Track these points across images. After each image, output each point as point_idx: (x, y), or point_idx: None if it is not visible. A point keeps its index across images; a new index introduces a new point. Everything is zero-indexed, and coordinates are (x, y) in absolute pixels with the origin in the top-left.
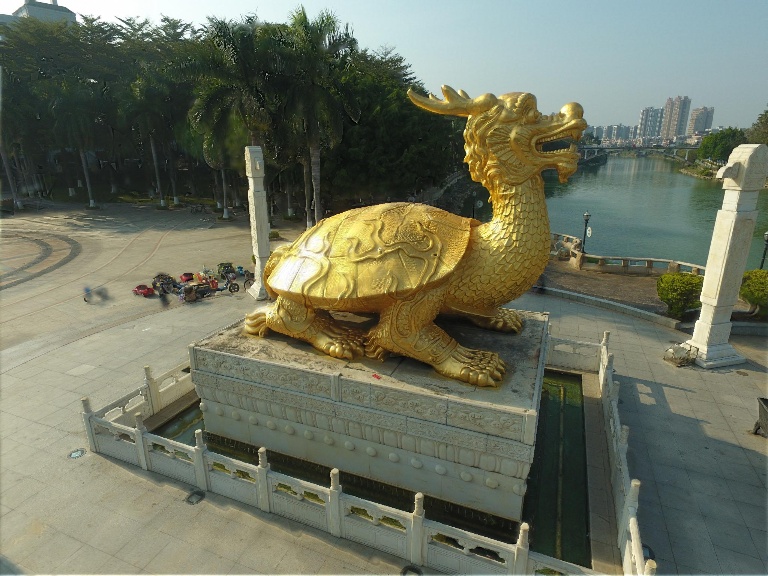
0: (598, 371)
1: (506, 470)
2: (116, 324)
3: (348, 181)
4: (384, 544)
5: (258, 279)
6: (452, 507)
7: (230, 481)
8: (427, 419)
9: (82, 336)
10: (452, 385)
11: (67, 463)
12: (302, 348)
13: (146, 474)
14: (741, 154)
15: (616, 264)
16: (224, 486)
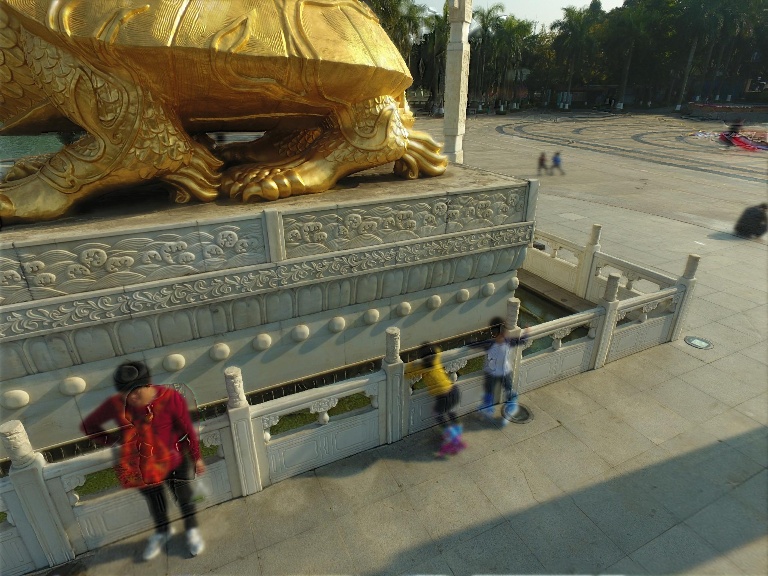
0: None
1: None
2: (734, 233)
3: None
4: None
5: None
6: None
7: None
8: None
9: (686, 220)
10: None
11: None
12: None
13: None
14: None
15: None
16: None
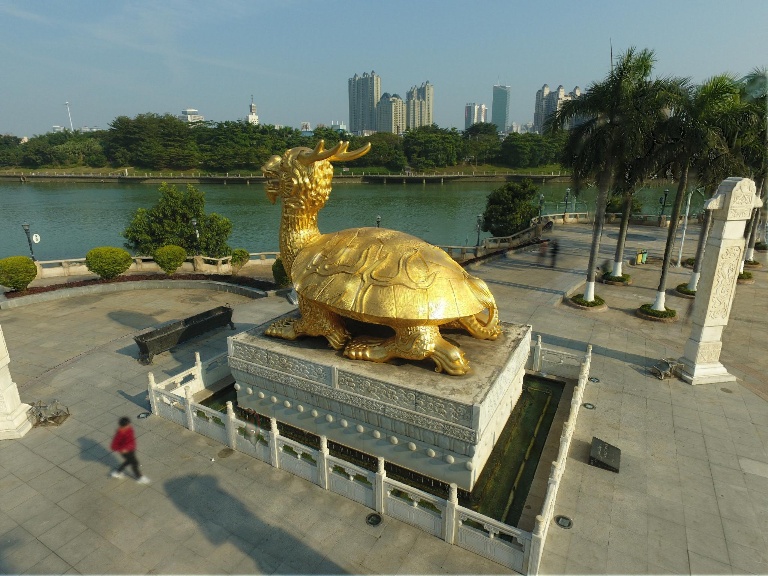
0: None
1: None
2: None
3: None
4: None
5: None
6: None
7: None
8: None
9: None
10: None
11: (591, 375)
12: None
13: None
14: None
15: None
16: None
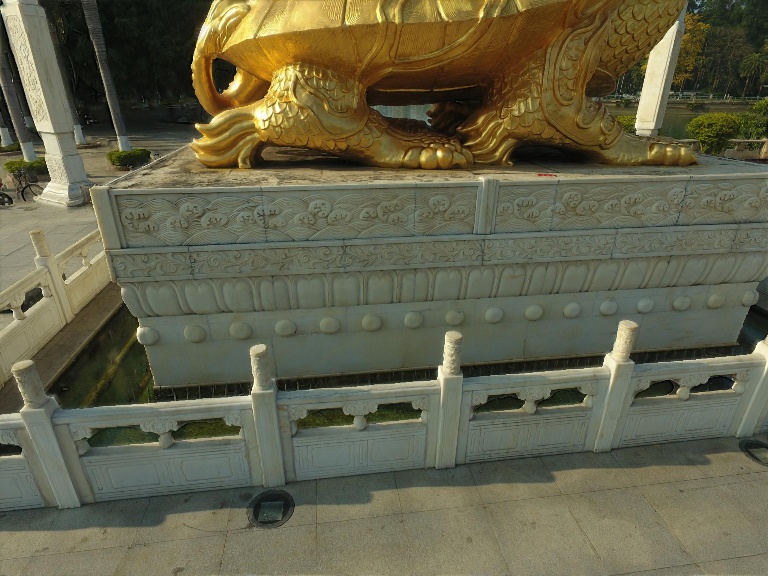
0: None
1: (744, 273)
2: None
3: (121, 69)
4: (691, 427)
5: (58, 174)
6: (665, 354)
7: (355, 438)
8: (646, 224)
9: None
10: (654, 169)
11: None
12: (354, 169)
13: (84, 515)
14: None
15: None
16: (335, 456)
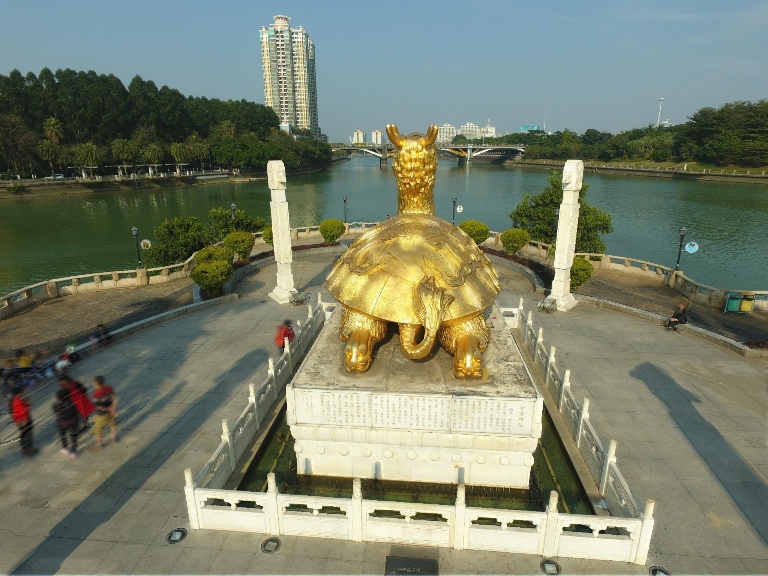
0: (323, 321)
1: None
2: None
3: None
4: None
5: None
6: None
7: None
8: None
9: None
10: None
11: (676, 570)
12: None
13: None
14: (279, 167)
15: (1, 307)
16: None
